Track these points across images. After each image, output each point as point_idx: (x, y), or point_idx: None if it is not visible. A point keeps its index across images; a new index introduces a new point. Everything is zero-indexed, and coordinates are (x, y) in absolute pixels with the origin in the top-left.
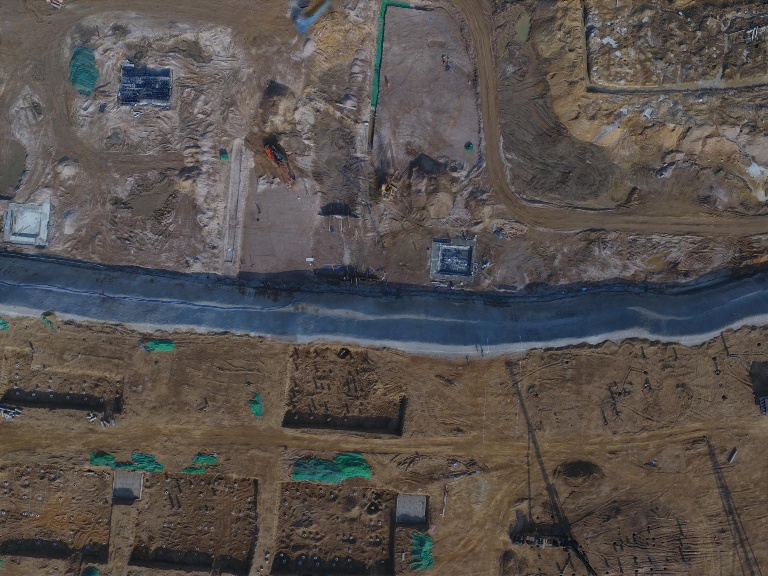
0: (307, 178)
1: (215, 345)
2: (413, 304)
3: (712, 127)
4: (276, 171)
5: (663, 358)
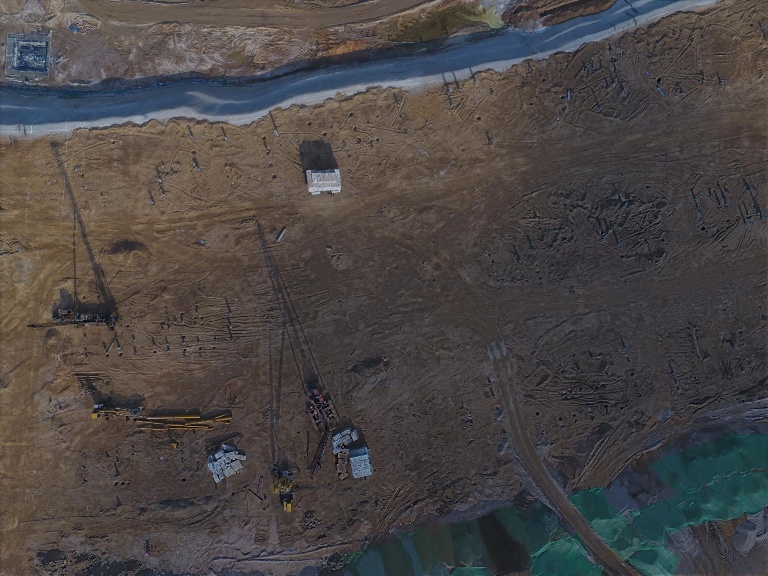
0: None
1: None
2: None
3: None
4: None
5: (212, 138)
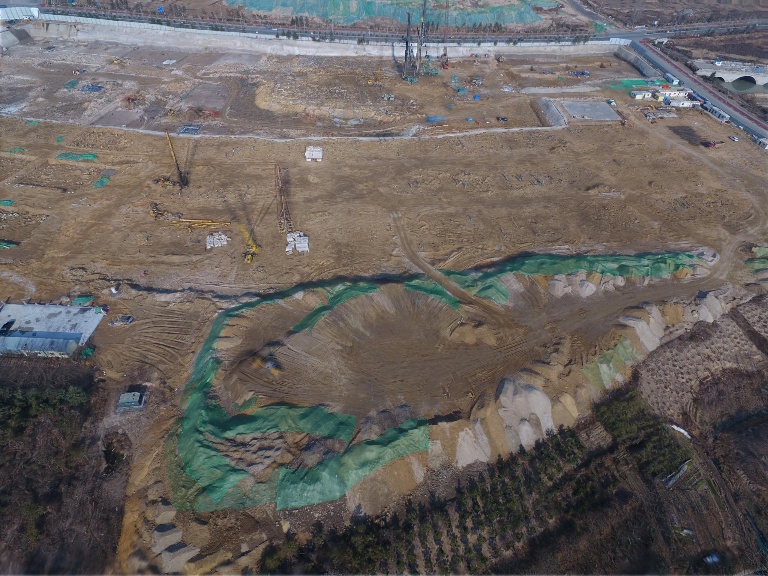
0: None
1: None
2: None
3: (317, 107)
4: (128, 106)
5: None
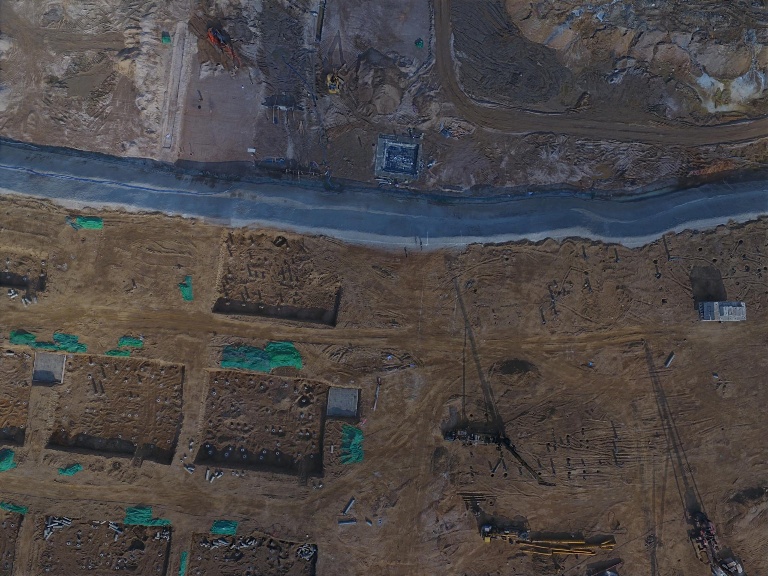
0: (252, 67)
1: (145, 225)
2: (355, 198)
3: (664, 33)
4: (220, 57)
5: (604, 259)
